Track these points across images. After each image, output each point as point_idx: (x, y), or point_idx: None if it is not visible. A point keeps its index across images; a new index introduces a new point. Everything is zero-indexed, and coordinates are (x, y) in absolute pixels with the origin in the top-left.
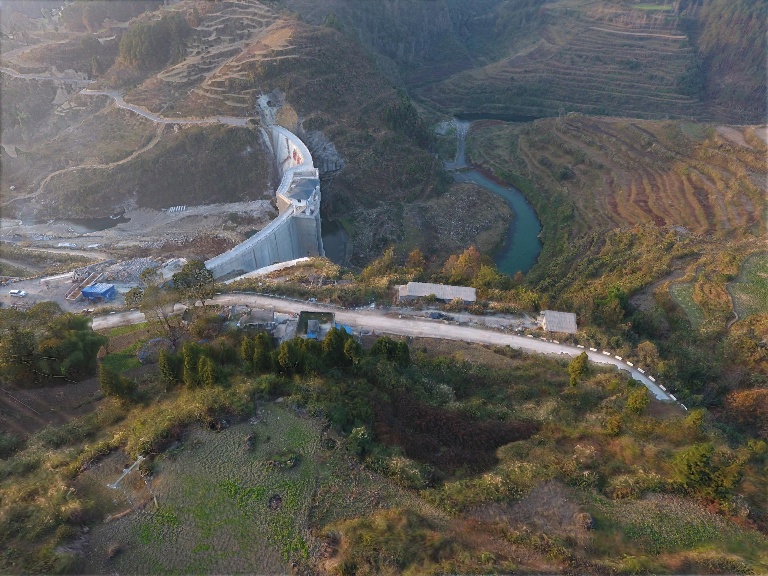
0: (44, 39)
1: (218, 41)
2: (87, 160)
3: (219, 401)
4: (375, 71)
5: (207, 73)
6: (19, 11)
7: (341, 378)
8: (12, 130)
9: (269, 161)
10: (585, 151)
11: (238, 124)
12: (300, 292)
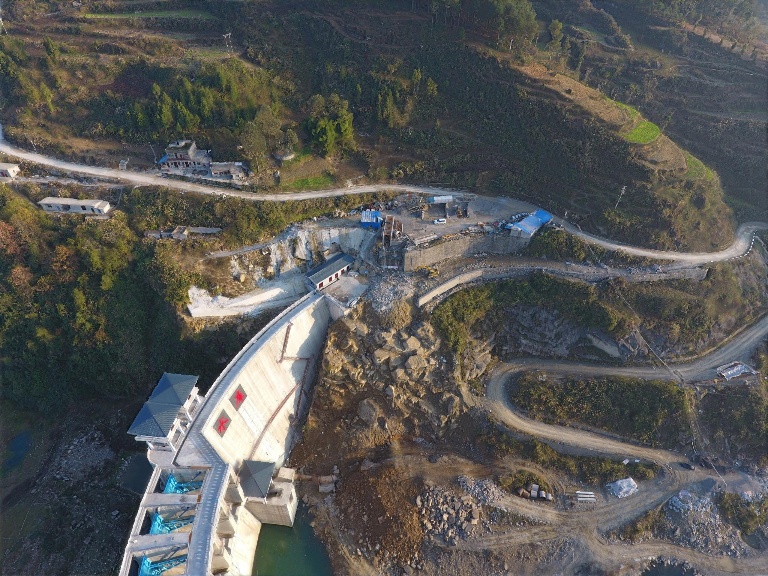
0: None
1: None
2: None
3: (211, 62)
4: None
5: None
6: None
7: (166, 93)
8: None
9: None
10: None
11: None
12: (193, 199)
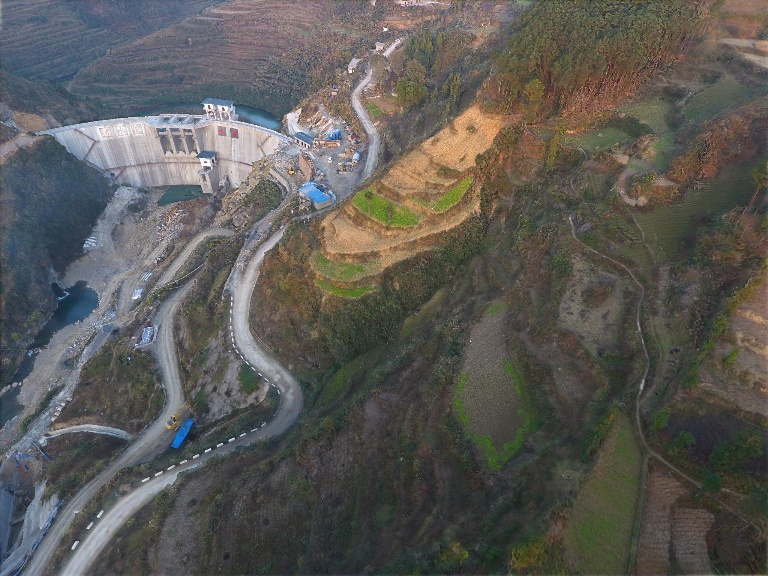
0: None
1: None
2: None
3: None
4: None
5: None
6: None
7: None
8: None
9: None
10: (163, 62)
11: (32, 140)
12: None
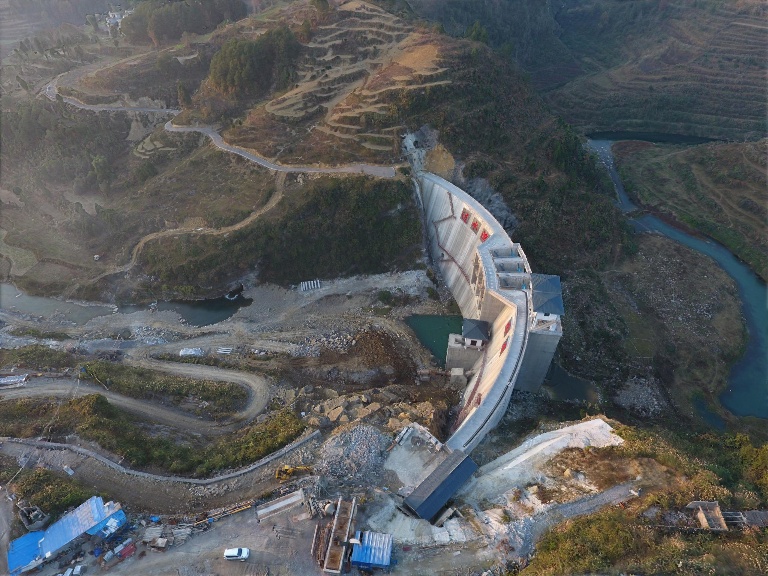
0: (101, 55)
1: (337, 61)
2: (188, 221)
3: None
4: (533, 95)
5: (327, 103)
6: (55, 16)
7: None
8: (85, 178)
9: (421, 220)
10: None
11: (386, 175)
12: (748, 575)
